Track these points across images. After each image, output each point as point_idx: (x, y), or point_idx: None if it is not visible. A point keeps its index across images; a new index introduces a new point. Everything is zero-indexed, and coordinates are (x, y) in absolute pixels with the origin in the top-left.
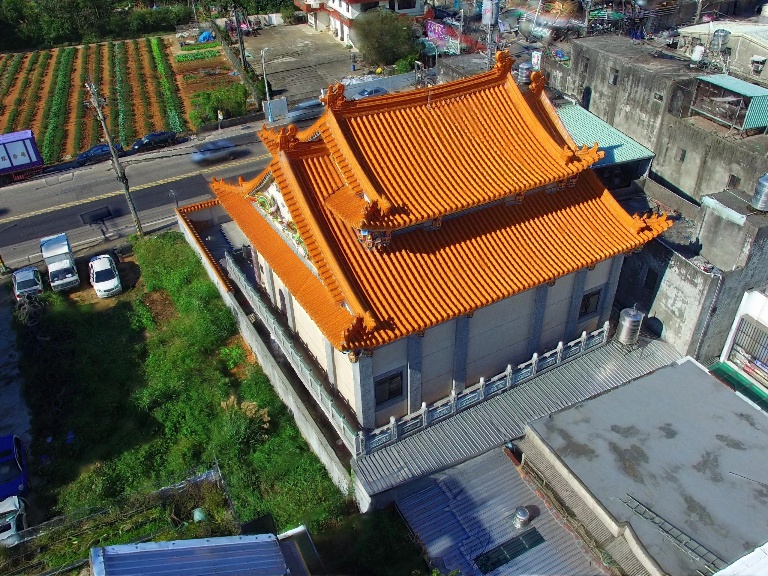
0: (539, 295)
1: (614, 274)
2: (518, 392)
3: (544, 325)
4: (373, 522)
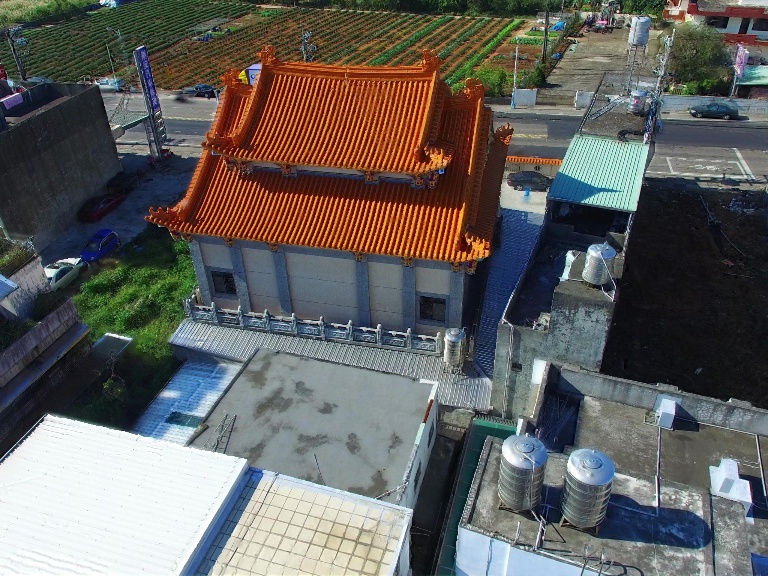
0: (358, 268)
1: (454, 289)
2: (328, 346)
3: (376, 304)
4: (165, 362)
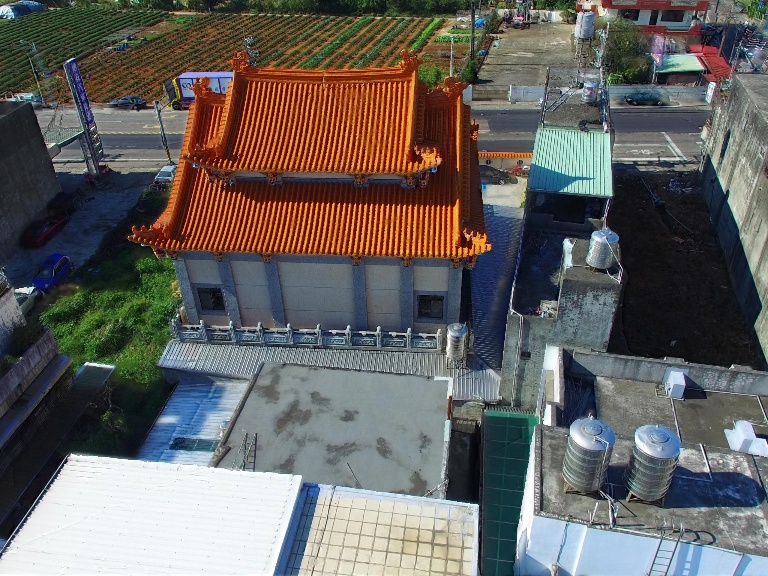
0: (354, 272)
1: (452, 285)
2: (327, 353)
3: (372, 306)
4: (155, 387)
